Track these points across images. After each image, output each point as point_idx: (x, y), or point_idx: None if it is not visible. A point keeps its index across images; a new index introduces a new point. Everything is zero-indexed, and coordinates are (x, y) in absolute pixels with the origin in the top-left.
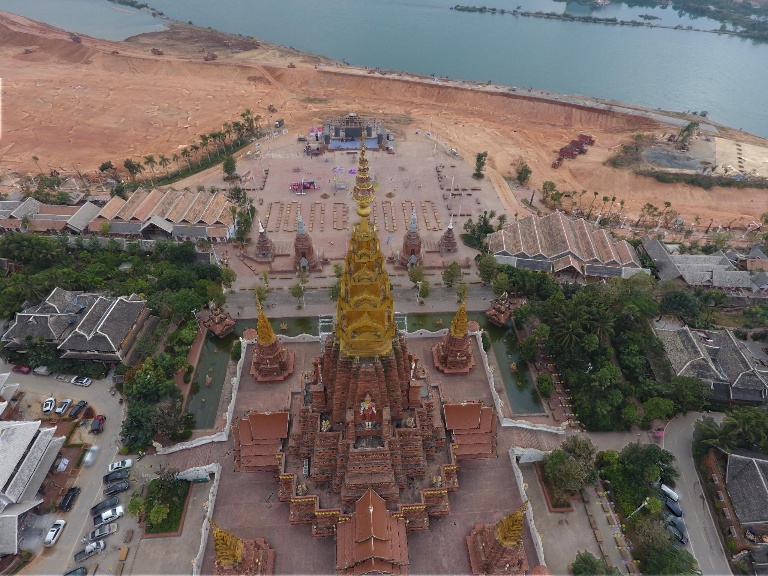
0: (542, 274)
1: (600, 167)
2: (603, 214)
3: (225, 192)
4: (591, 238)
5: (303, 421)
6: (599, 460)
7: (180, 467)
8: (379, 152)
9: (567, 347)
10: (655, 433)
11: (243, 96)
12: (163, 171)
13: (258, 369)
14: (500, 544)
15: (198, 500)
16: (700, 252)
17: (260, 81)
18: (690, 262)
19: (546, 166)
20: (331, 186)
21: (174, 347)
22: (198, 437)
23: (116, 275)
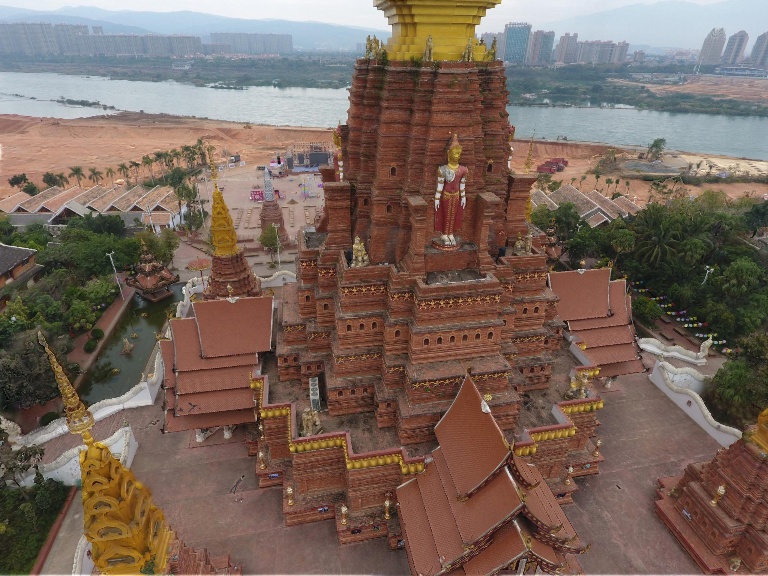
0: None
1: None
2: None
3: None
4: None
5: (306, 286)
6: None
7: (52, 460)
8: None
9: None
10: None
11: None
12: None
13: None
14: None
15: None
16: None
17: None
18: None
19: None
20: (299, 195)
21: (72, 300)
22: None
23: None
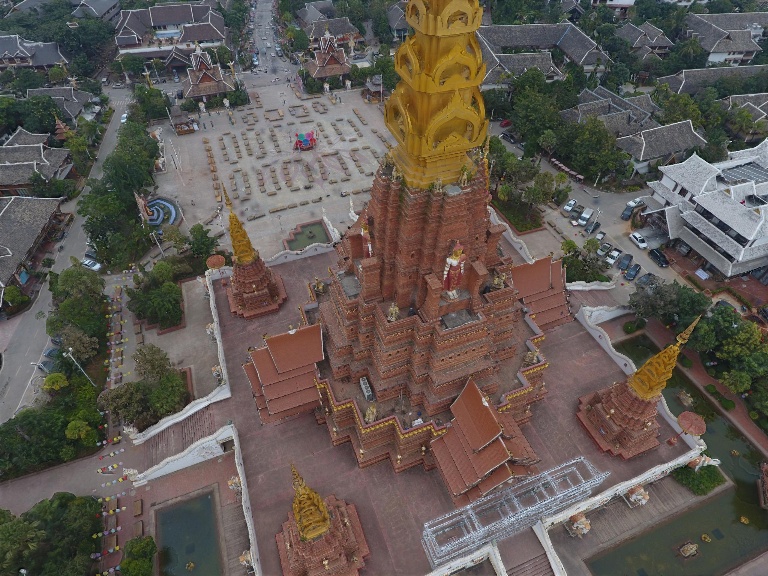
0: None
1: None
2: None
3: None
4: None
5: None
6: None
7: None
8: None
9: None
10: None
11: None
12: None
13: None
14: None
15: None
16: None
17: None
18: None
19: None
20: None
21: None
22: (616, 332)
23: None
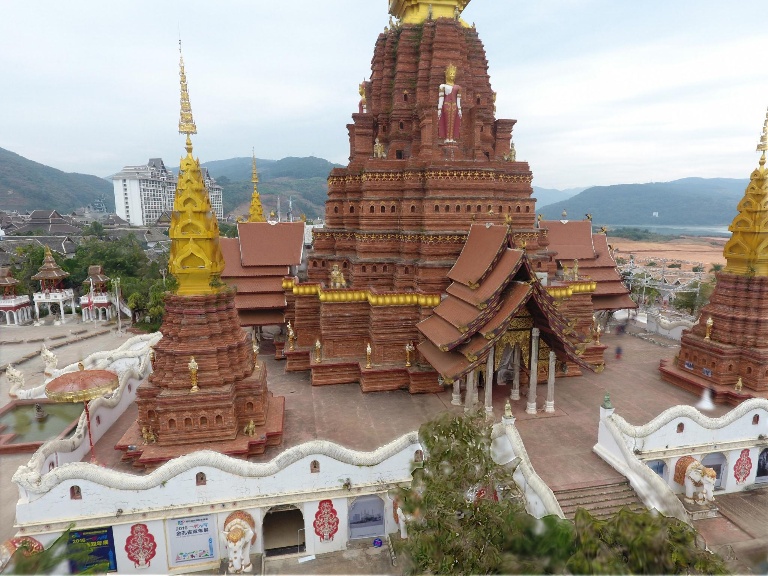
0: None
1: None
2: None
3: None
4: None
5: None
6: None
7: None
8: None
9: None
10: None
11: None
12: None
13: None
14: None
15: None
16: None
17: None
18: None
19: None
20: None
21: None
22: None
23: None
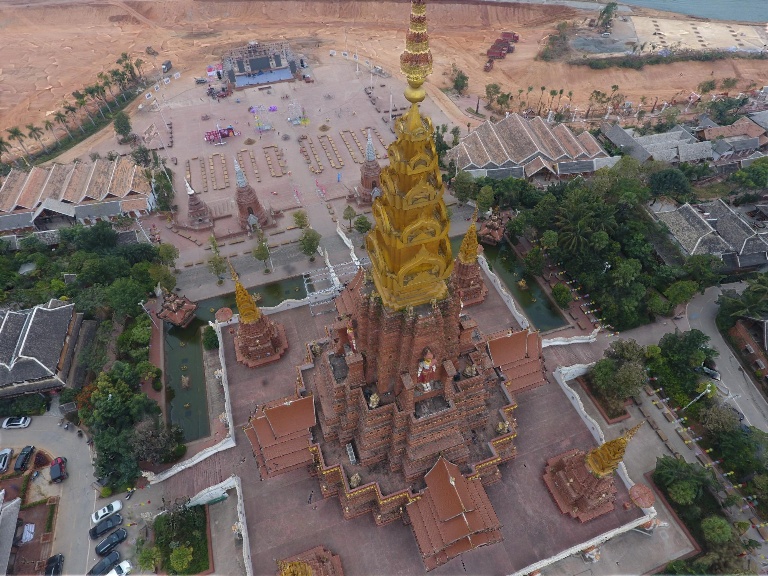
0: (521, 181)
1: (533, 63)
2: (555, 109)
3: (126, 157)
4: (553, 135)
5: (338, 401)
6: (641, 359)
7: (186, 492)
8: (295, 82)
9: (576, 250)
10: (679, 318)
11: (109, 42)
12: (36, 146)
13: (246, 353)
14: (596, 477)
15: (221, 524)
16: (654, 132)
17: (125, 21)
18: (654, 142)
19: (478, 71)
20: (253, 129)
21: (129, 352)
22: (195, 450)
23: (18, 281)
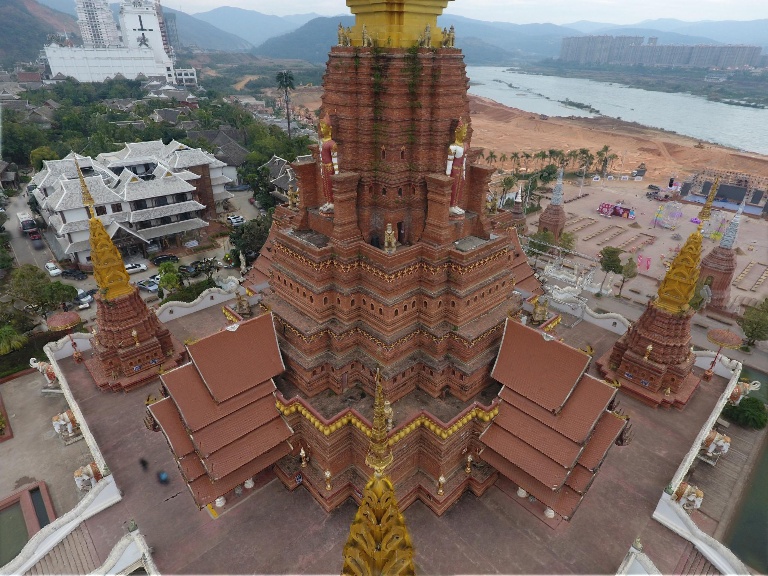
0: None
1: None
2: None
3: None
4: None
5: None
6: None
7: None
8: (758, 220)
9: None
10: None
11: None
12: None
13: None
14: None
15: None
16: None
17: (649, 152)
18: None
19: None
20: None
21: None
22: None
23: None
